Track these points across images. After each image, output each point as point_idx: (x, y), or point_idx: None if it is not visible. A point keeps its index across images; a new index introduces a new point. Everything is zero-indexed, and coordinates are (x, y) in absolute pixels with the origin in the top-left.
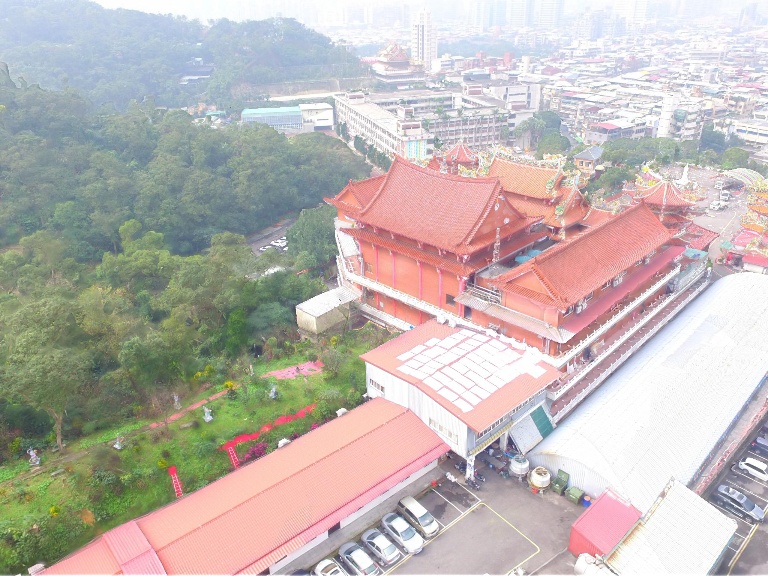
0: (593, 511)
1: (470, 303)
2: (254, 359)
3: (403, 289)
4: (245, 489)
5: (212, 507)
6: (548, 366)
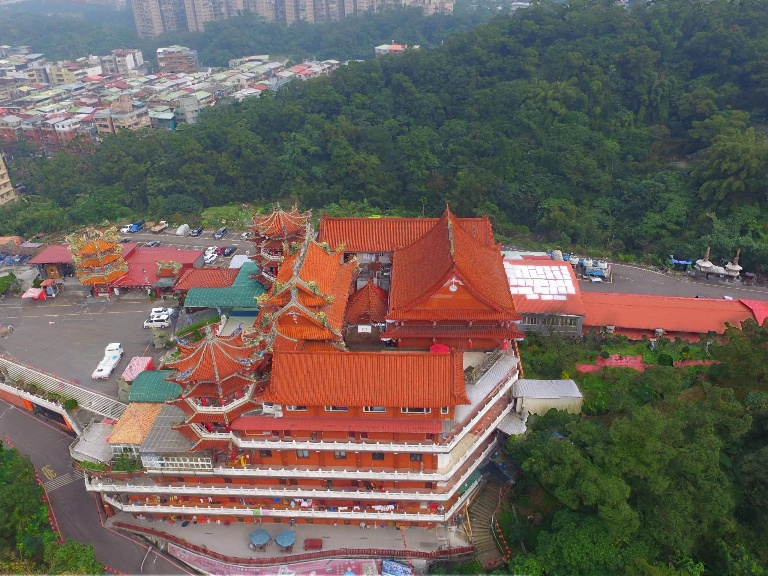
0: None
1: None
2: (643, 405)
3: None
4: (696, 316)
5: (717, 317)
6: None
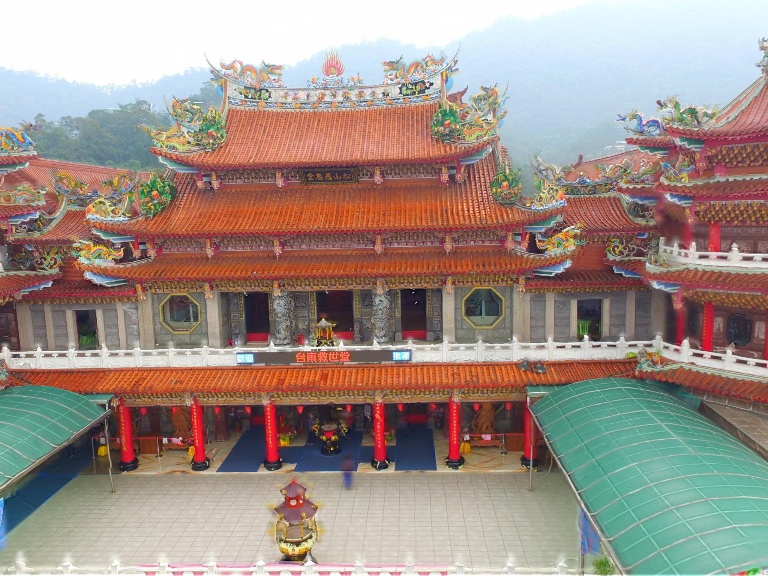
0: None
1: None
2: None
3: None
4: None
5: None
6: None
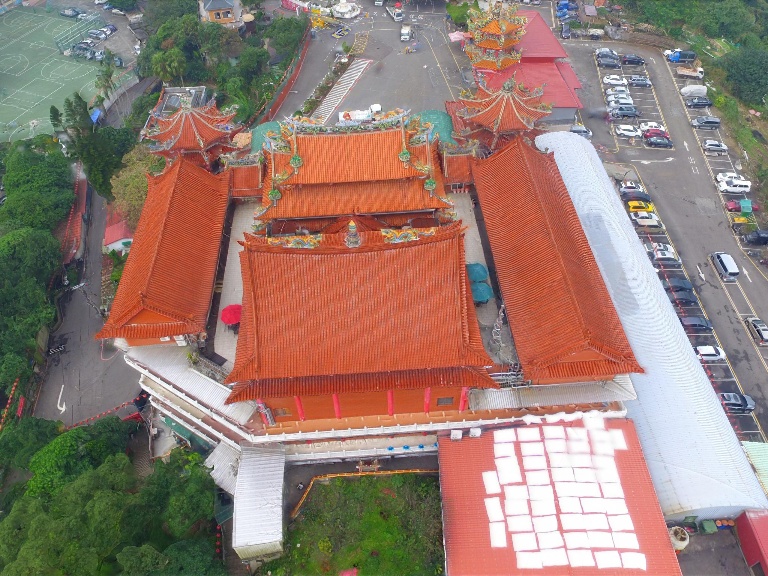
0: (766, 550)
1: (494, 403)
2: None
3: (356, 414)
4: None
5: None
6: (616, 422)
